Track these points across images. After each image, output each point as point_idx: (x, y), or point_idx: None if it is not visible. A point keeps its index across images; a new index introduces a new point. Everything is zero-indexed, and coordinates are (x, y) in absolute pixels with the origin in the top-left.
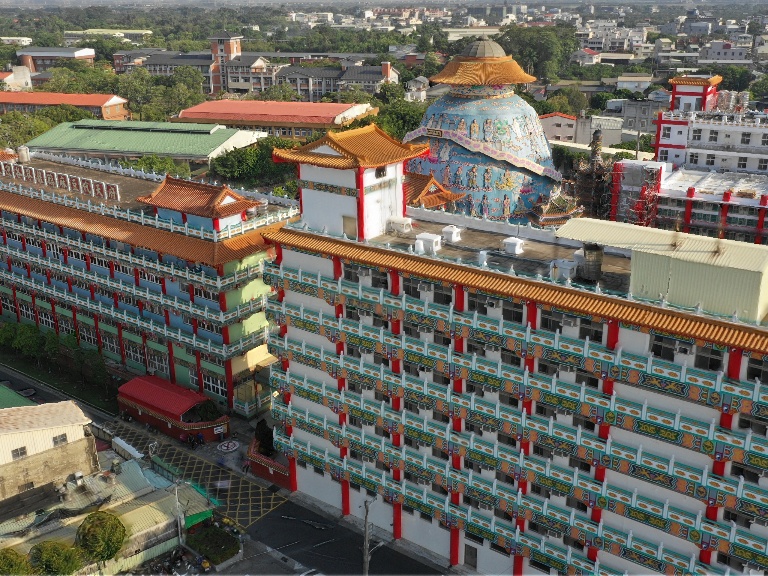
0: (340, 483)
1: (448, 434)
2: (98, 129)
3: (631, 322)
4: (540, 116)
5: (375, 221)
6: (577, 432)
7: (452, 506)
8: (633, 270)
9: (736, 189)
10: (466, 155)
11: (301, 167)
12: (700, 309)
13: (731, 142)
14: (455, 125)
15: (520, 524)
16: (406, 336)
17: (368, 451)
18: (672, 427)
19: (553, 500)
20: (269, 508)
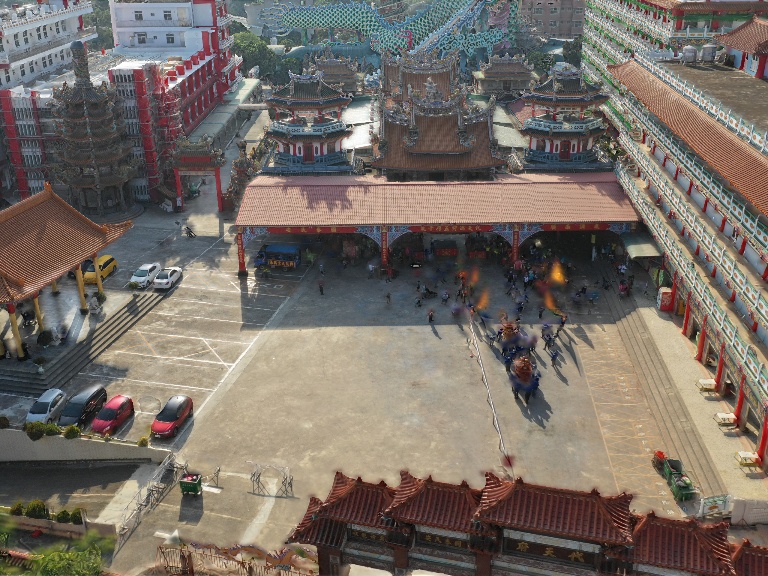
0: None
1: None
2: None
3: None
4: None
5: None
6: None
7: None
8: None
9: None
10: None
11: None
12: None
13: (12, 48)
14: None
15: None
16: None
17: None
18: None
19: None
20: None
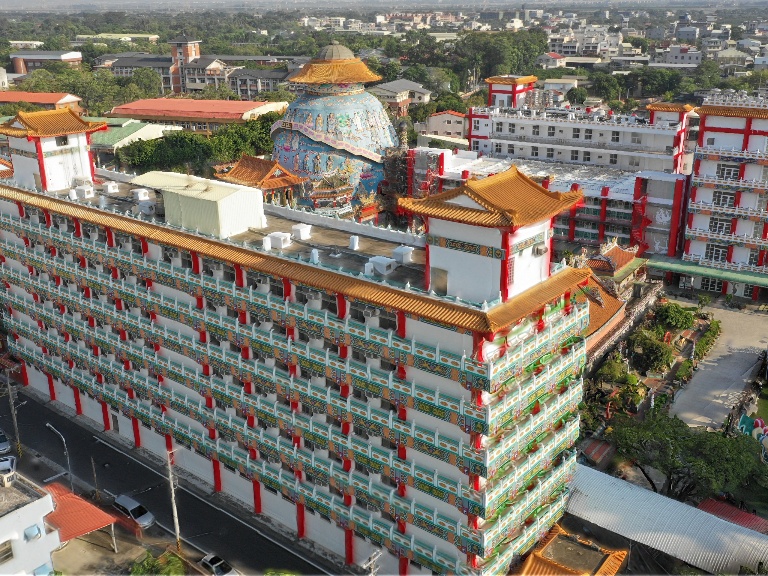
0: (47, 375)
1: (85, 329)
2: None
3: (145, 237)
4: (435, 114)
5: (59, 178)
6: (138, 319)
7: (96, 384)
8: (165, 204)
9: None
10: (312, 144)
11: (8, 138)
12: (183, 227)
13: (525, 133)
14: (304, 118)
15: (129, 392)
16: (56, 258)
17: (52, 347)
18: (174, 309)
19: (140, 372)
20: (0, 395)
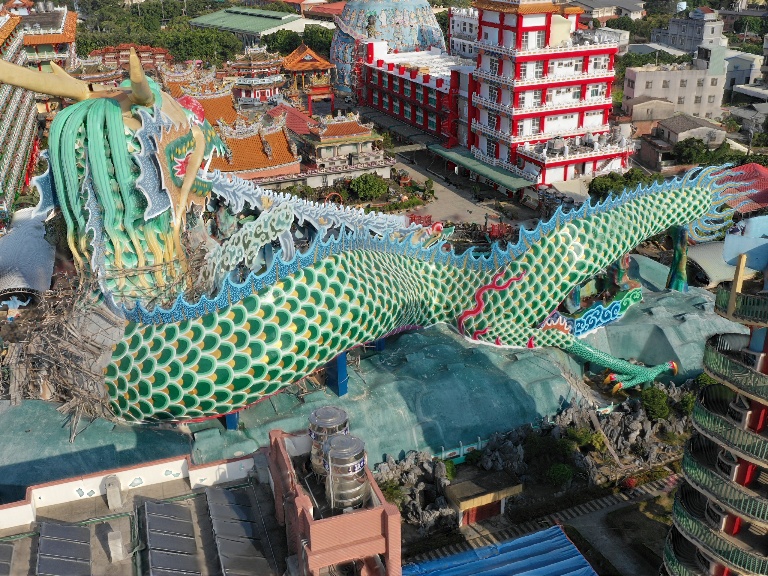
0: None
1: None
2: (235, 13)
3: None
4: None
5: None
6: None
7: None
8: None
9: (423, 66)
10: (344, 36)
11: None
12: None
13: None
14: (346, 13)
15: None
16: None
17: None
18: None
19: None
20: None
